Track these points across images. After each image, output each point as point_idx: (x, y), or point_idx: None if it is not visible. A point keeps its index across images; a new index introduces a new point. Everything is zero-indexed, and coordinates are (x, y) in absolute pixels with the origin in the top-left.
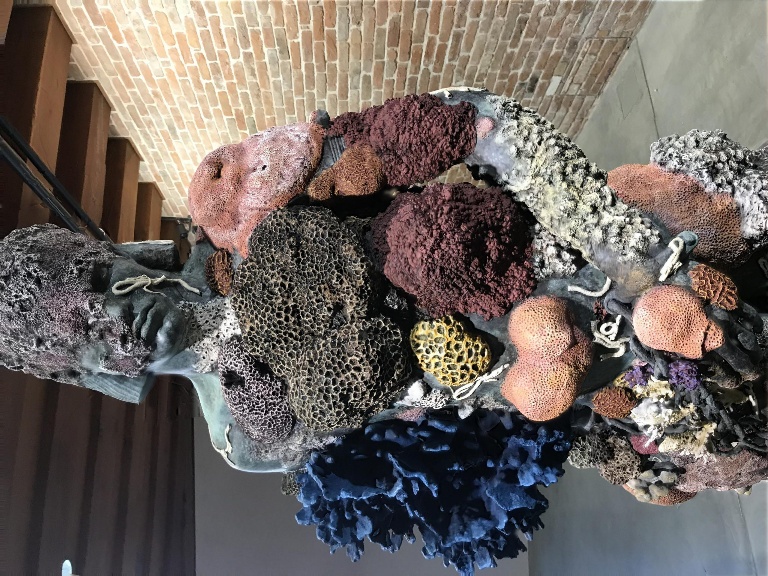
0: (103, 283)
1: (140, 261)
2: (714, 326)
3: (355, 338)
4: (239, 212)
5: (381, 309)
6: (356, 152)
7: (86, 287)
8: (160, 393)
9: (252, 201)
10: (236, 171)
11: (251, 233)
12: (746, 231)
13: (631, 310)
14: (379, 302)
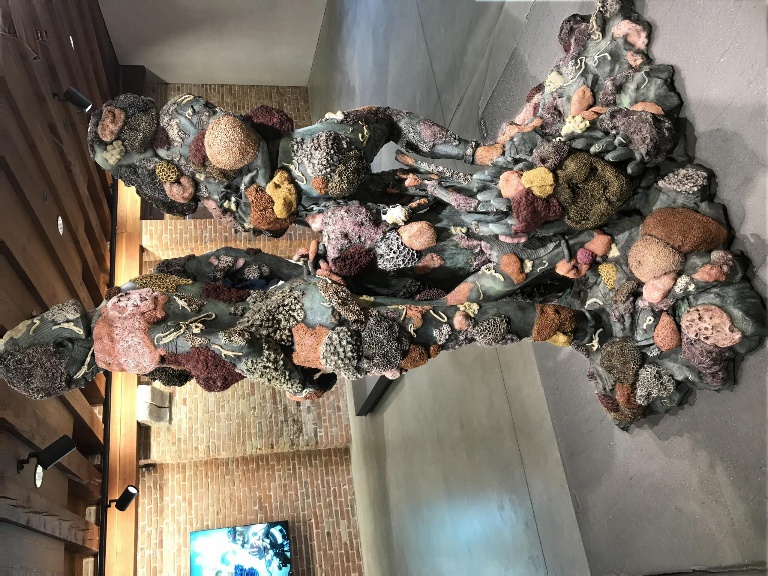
0: None
1: (69, 339)
2: None
3: None
4: None
5: None
6: None
7: None
8: None
9: None
10: None
11: None
12: None
13: None
14: None
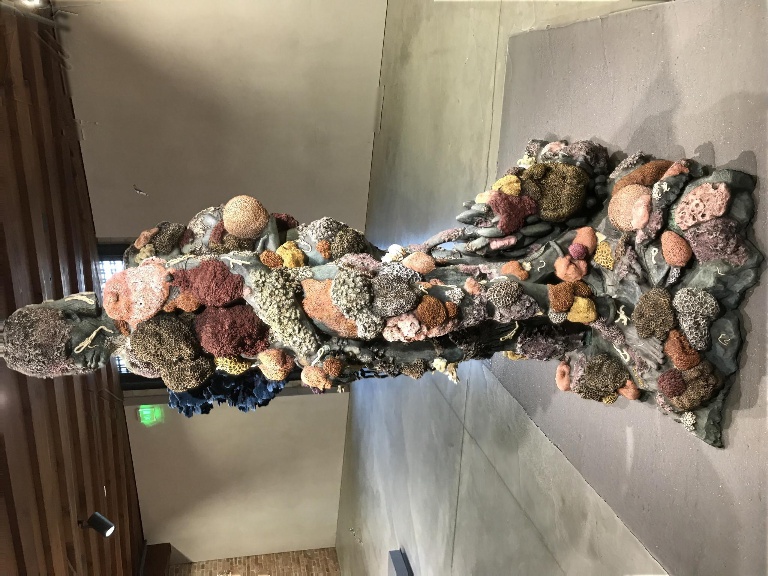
0: (70, 350)
1: (79, 314)
2: (328, 383)
3: (188, 370)
4: (130, 317)
5: (200, 353)
6: (186, 297)
7: (65, 359)
8: (43, 117)
9: (136, 317)
10: (127, 303)
11: (137, 323)
12: (358, 334)
13: (303, 367)
14: (199, 351)
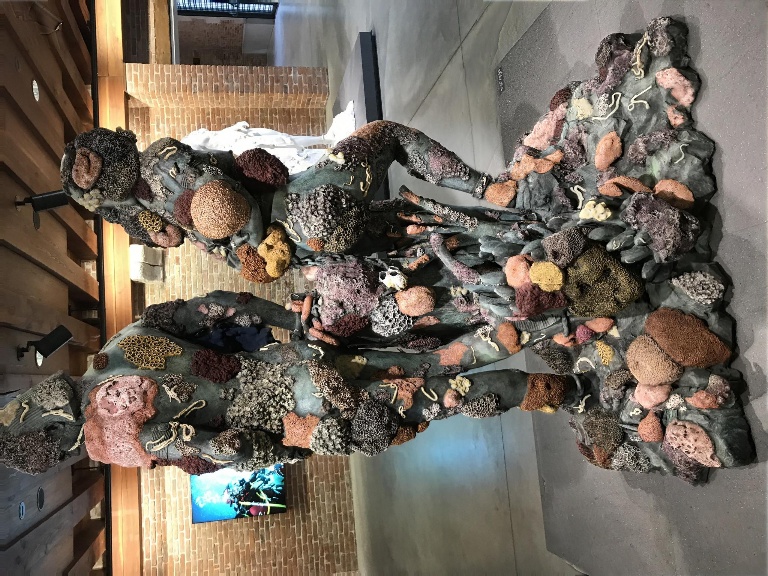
0: None
1: None
2: None
3: None
4: None
5: None
6: None
7: None
8: None
9: None
10: None
11: None
12: None
13: None
14: None
